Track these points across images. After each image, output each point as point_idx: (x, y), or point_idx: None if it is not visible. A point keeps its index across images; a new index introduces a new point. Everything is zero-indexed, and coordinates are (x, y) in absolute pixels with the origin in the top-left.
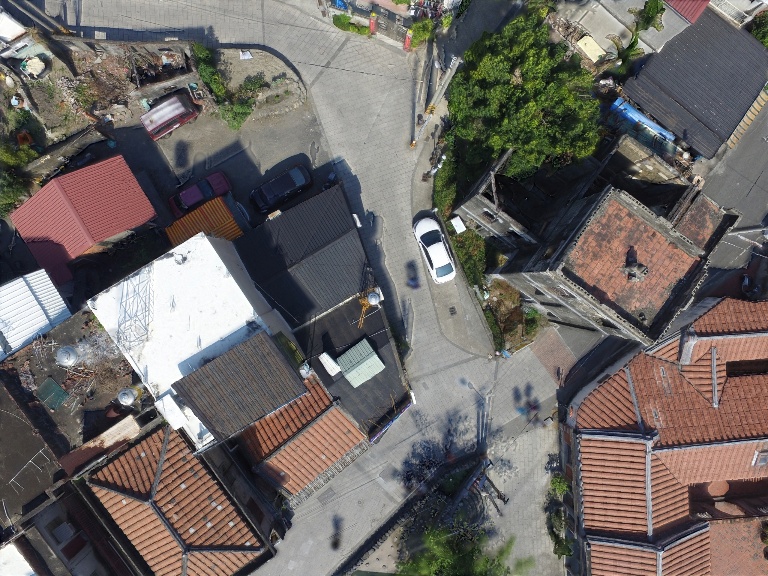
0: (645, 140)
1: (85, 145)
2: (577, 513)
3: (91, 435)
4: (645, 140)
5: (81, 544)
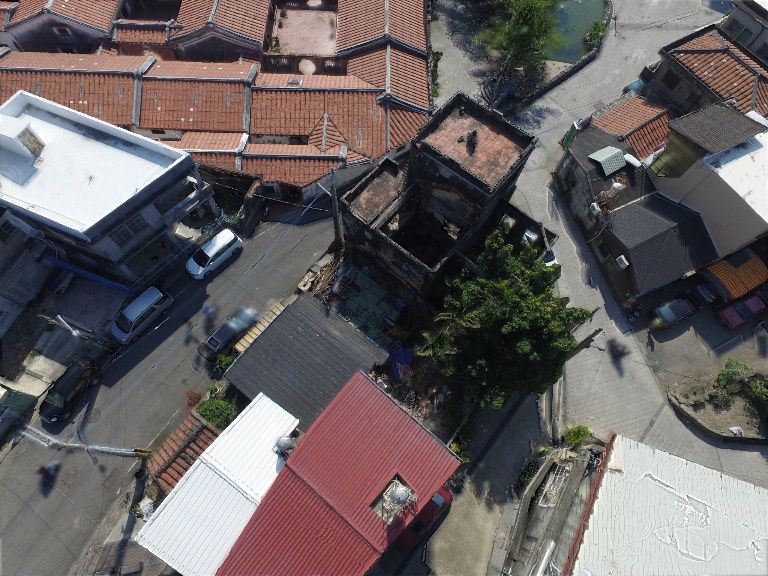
0: (359, 318)
1: None
2: None
3: None
4: (359, 318)
5: None
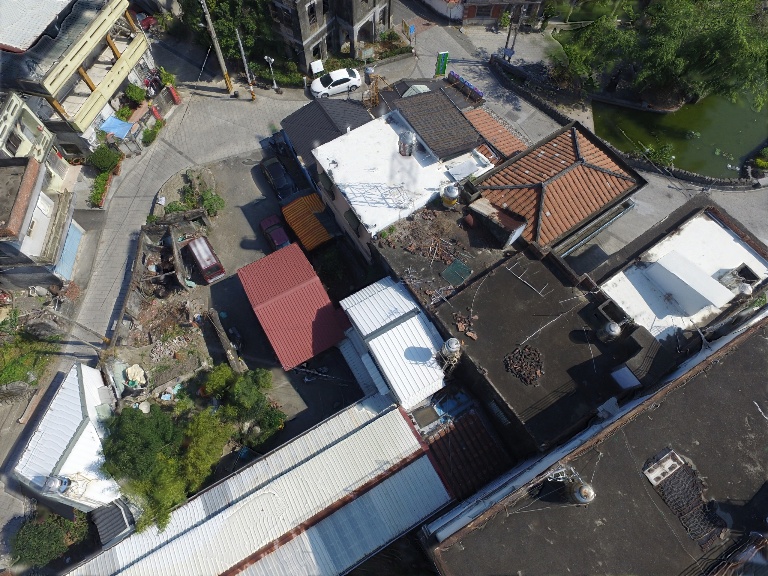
0: None
1: None
2: (522, 1)
3: (491, 240)
4: None
5: None
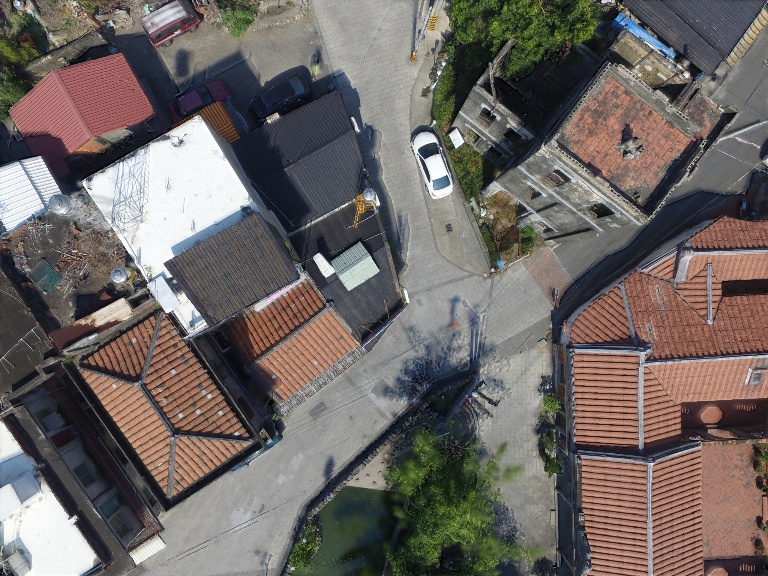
0: None
1: (86, 48)
2: (569, 429)
3: None
4: None
5: (71, 437)
